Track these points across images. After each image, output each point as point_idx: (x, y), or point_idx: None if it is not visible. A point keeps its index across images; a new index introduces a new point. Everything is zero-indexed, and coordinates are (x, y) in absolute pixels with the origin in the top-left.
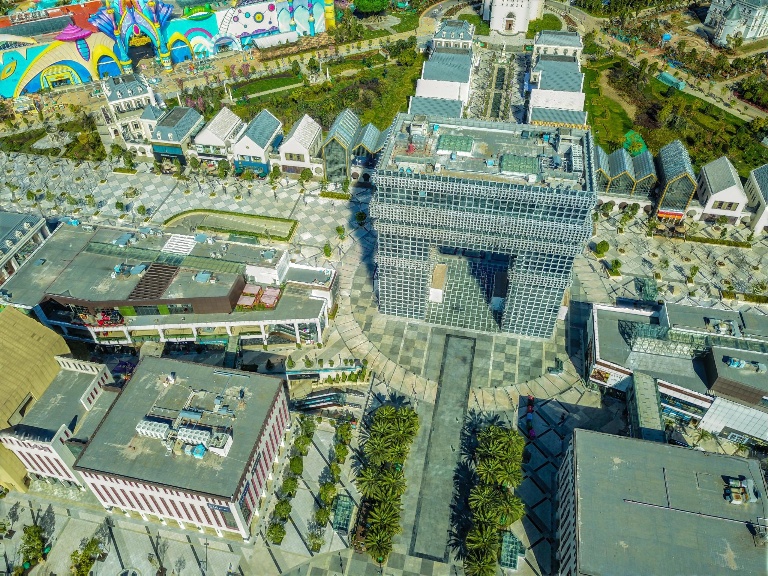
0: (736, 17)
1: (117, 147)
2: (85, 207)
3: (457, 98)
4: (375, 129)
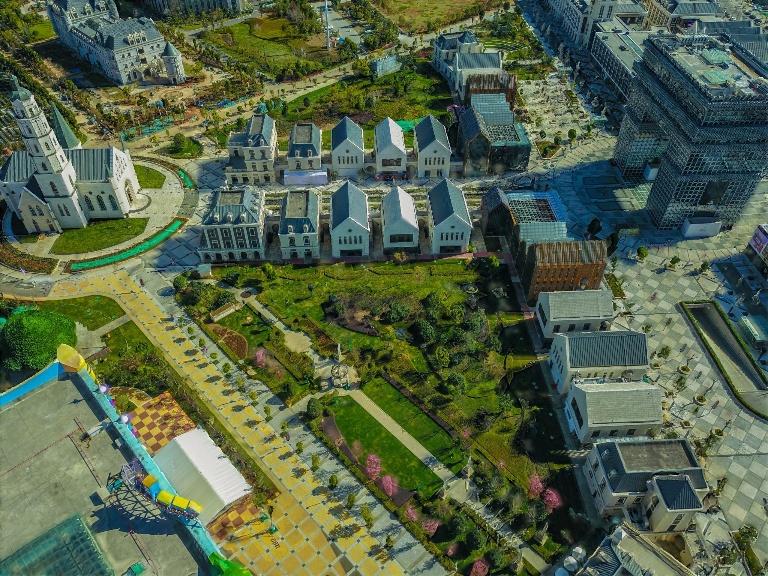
0: (177, 51)
1: (735, 575)
2: None
3: None
4: None
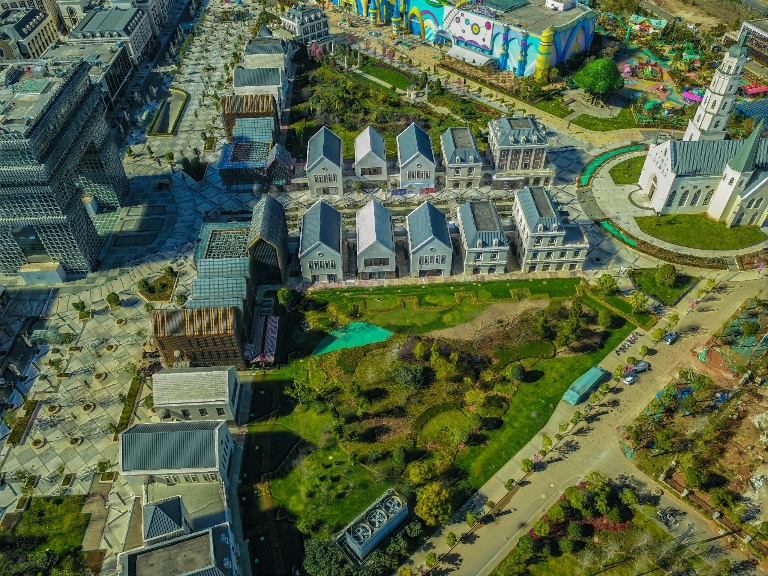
0: None
1: None
2: (192, 60)
3: (357, 161)
4: (271, 124)
